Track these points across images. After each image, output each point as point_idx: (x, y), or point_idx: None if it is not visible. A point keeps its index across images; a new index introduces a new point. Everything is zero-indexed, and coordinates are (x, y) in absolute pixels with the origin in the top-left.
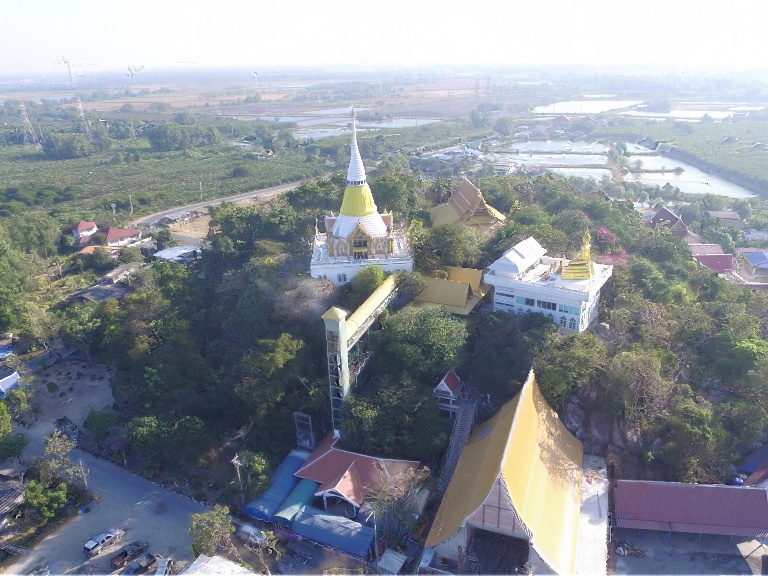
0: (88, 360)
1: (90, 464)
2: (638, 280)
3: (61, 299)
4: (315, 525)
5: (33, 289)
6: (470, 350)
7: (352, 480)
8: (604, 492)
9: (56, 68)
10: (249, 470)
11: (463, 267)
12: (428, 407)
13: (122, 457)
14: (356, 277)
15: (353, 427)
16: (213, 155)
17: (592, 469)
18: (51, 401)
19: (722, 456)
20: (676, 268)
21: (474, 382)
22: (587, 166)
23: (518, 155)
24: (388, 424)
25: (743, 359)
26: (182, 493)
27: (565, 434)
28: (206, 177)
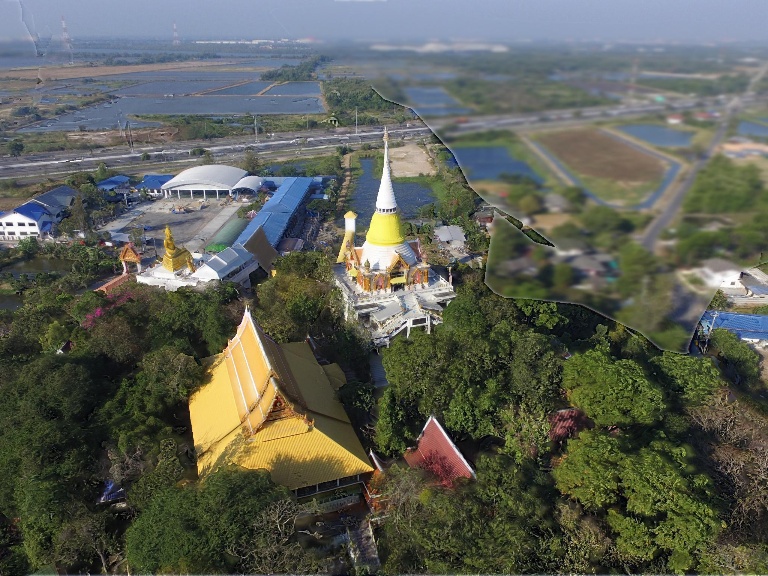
0: None
1: None
2: None
3: None
4: None
5: None
6: None
7: None
8: None
9: None
10: None
11: None
12: None
13: None
14: None
15: None
16: None
17: None
18: None
19: None
20: None
21: None
22: None
23: None
24: None
25: None
26: None
27: None
28: None
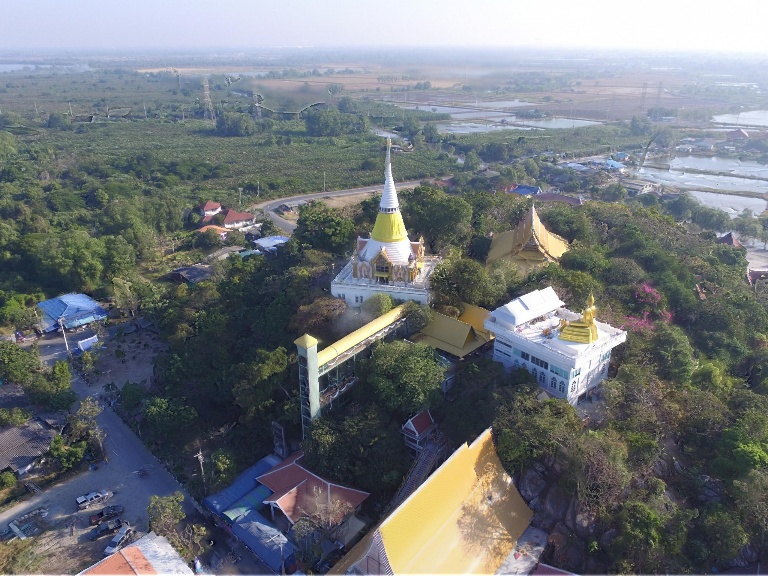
0: (159, 333)
1: (117, 428)
2: (657, 351)
3: (167, 272)
4: (249, 530)
5: (150, 260)
6: (456, 393)
7: (297, 497)
8: (524, 571)
9: (168, 76)
10: (215, 466)
11: (480, 306)
12: (386, 443)
13: (138, 428)
14: (366, 302)
15: (310, 448)
16: (355, 144)
17: (528, 544)
18: (116, 365)
19: (670, 567)
20: (727, 341)
21: (443, 427)
22: (740, 193)
23: (668, 171)
24: (344, 452)
25: (742, 464)
26: (170, 471)
27: (515, 501)
28: (338, 167)
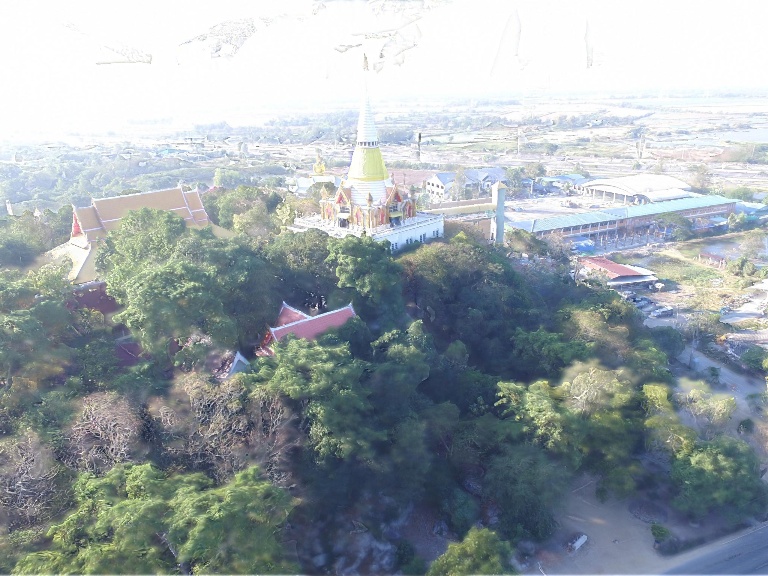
0: None
1: None
2: None
3: None
4: None
5: None
6: None
7: None
8: None
9: None
10: None
11: None
12: None
13: None
14: None
15: None
16: None
17: None
18: None
19: None
20: None
21: None
22: None
23: None
24: None
25: None
26: None
27: None
28: None
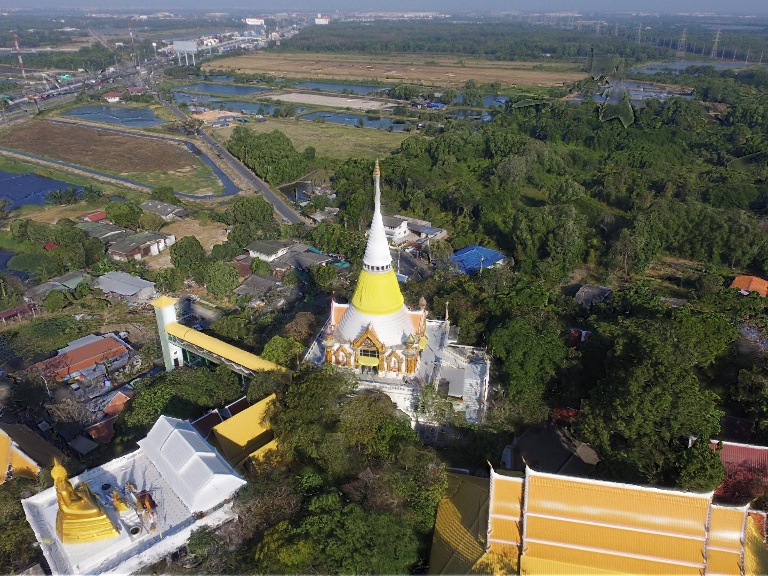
0: None
1: None
2: None
3: None
4: None
5: None
6: None
7: (123, 403)
8: None
9: None
10: None
11: None
12: None
13: None
14: None
15: None
16: None
17: None
18: None
19: None
20: None
21: None
22: None
23: None
24: None
25: None
26: None
27: None
28: None
